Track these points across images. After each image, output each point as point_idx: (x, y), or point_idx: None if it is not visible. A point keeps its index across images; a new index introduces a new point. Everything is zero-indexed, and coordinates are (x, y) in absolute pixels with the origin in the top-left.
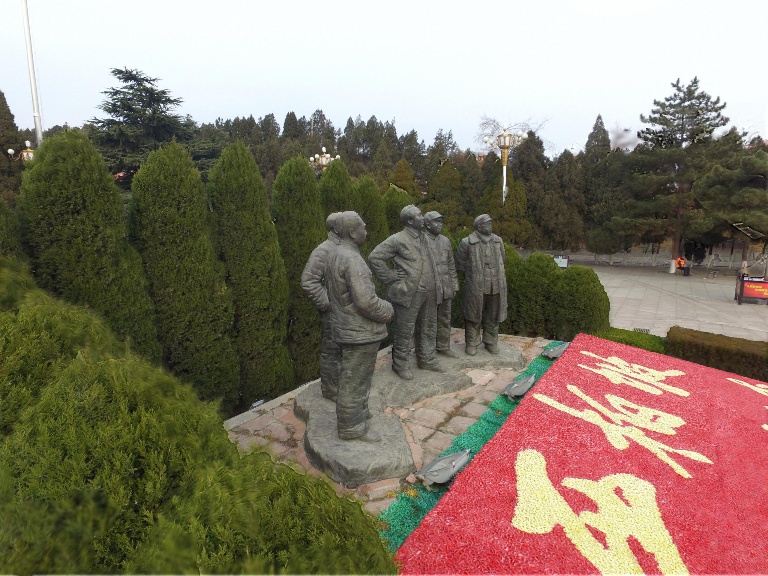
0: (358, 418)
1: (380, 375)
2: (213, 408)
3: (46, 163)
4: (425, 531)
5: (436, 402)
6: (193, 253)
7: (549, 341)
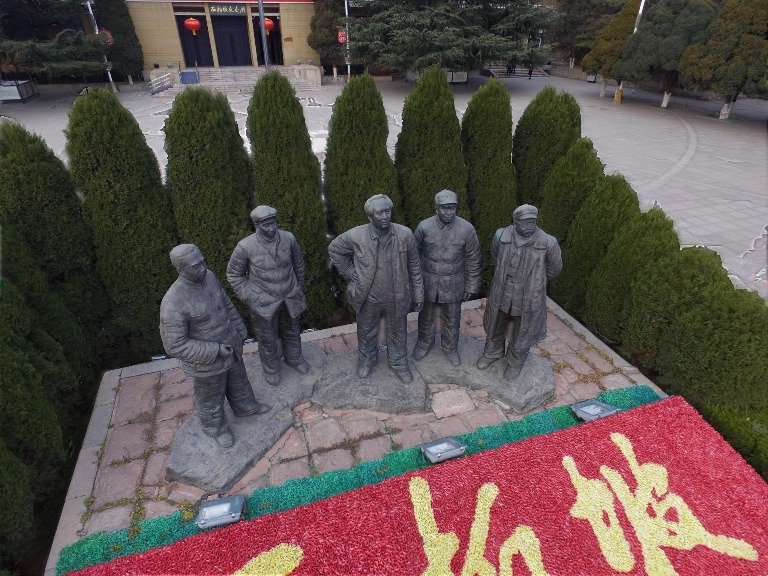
0: (209, 423)
1: (346, 358)
2: None
3: (70, 127)
4: (101, 571)
5: (356, 418)
6: (205, 200)
7: (640, 380)
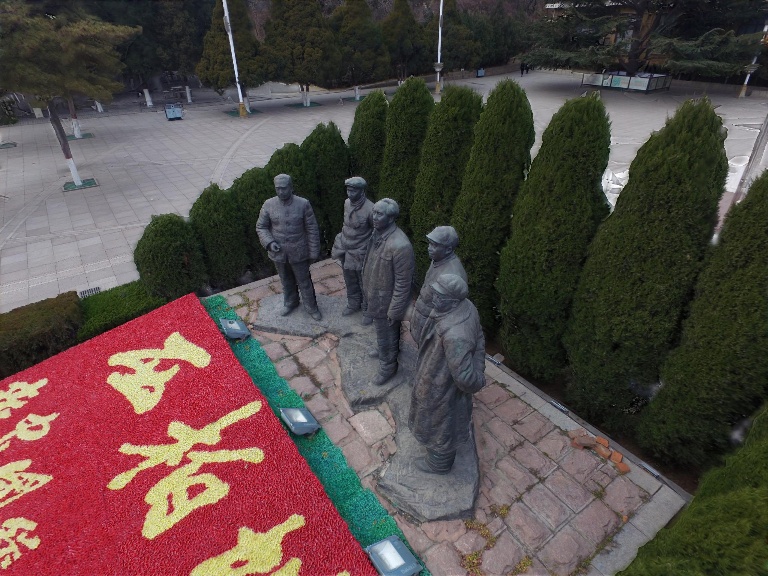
0: None
1: None
2: (219, 216)
3: None
4: None
5: (331, 367)
6: None
7: None
